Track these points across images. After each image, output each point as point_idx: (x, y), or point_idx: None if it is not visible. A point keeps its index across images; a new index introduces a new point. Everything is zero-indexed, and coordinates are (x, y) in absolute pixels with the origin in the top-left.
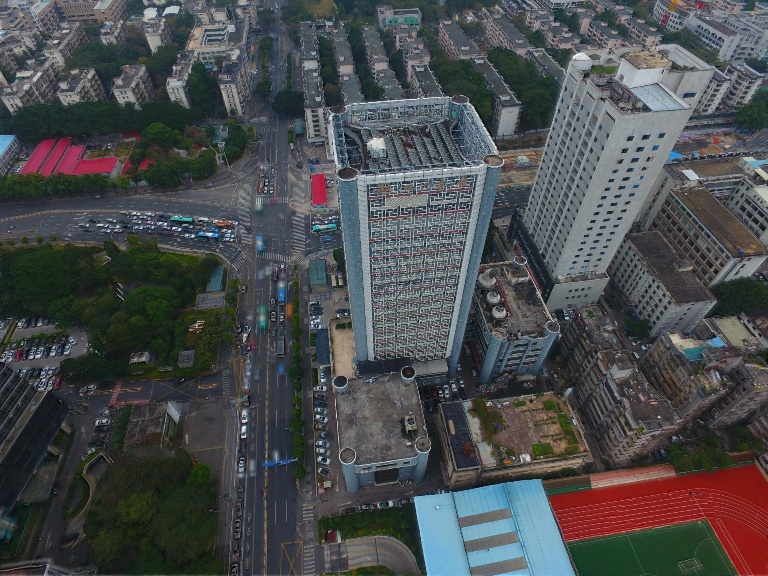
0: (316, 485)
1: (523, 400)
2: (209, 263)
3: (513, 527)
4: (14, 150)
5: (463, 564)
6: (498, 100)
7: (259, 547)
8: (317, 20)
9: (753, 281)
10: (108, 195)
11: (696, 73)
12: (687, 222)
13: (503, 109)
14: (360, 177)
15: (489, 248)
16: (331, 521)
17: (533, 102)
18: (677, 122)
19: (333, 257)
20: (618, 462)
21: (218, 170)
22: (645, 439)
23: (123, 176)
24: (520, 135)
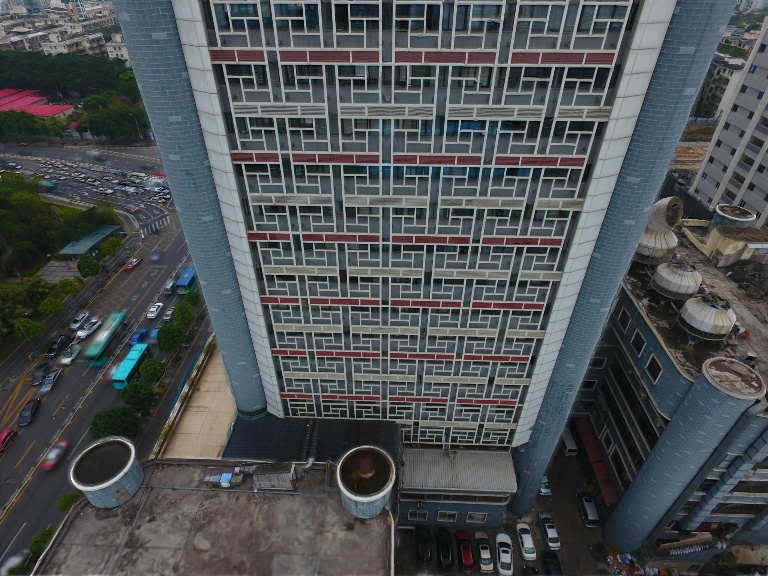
0: None
1: None
2: (93, 214)
3: None
4: None
5: None
6: None
7: None
8: None
9: None
10: (38, 144)
11: None
12: None
13: None
14: None
15: None
16: None
17: None
18: None
19: None
20: None
21: None
22: None
23: (59, 117)
24: None
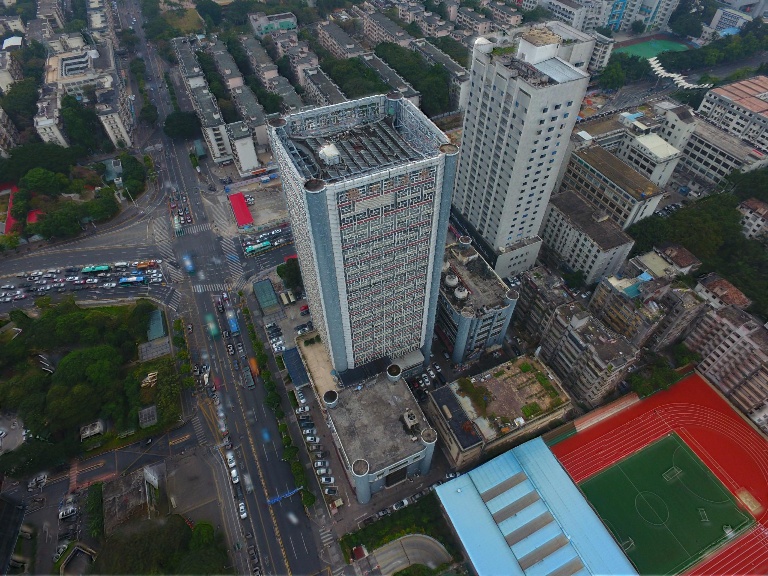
0: (327, 507)
1: (501, 369)
2: (143, 309)
3: (531, 487)
4: None
5: (497, 536)
6: None
7: None
8: (186, 35)
9: (656, 218)
10: None
11: (582, 44)
12: (592, 178)
13: None
14: (329, 186)
15: None
16: (354, 537)
17: (430, 90)
18: (581, 90)
19: (276, 275)
20: (593, 402)
21: (121, 208)
22: (614, 375)
23: (9, 235)
24: None
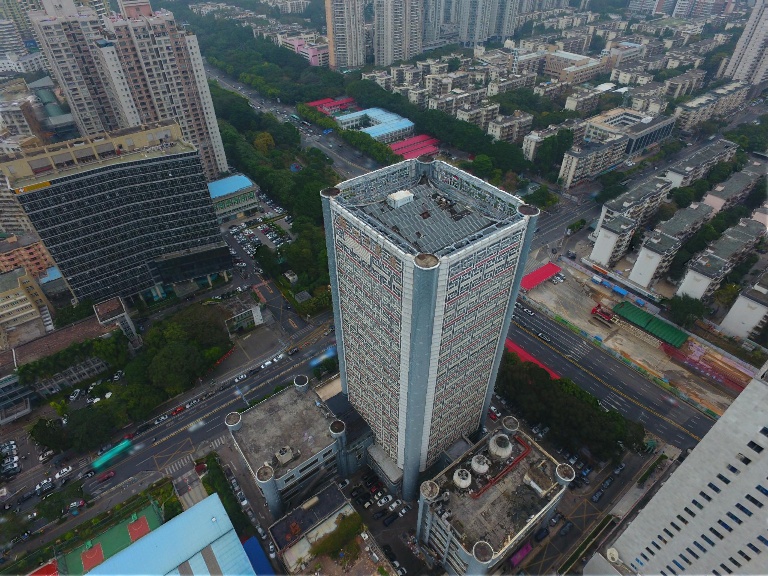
0: None
1: None
2: None
3: None
4: (406, 132)
5: (166, 568)
6: None
7: (183, 424)
8: (767, 150)
9: None
10: None
11: None
12: None
13: None
14: (330, 198)
15: (599, 451)
16: (211, 459)
17: None
18: None
19: None
20: None
21: None
22: None
23: None
24: None
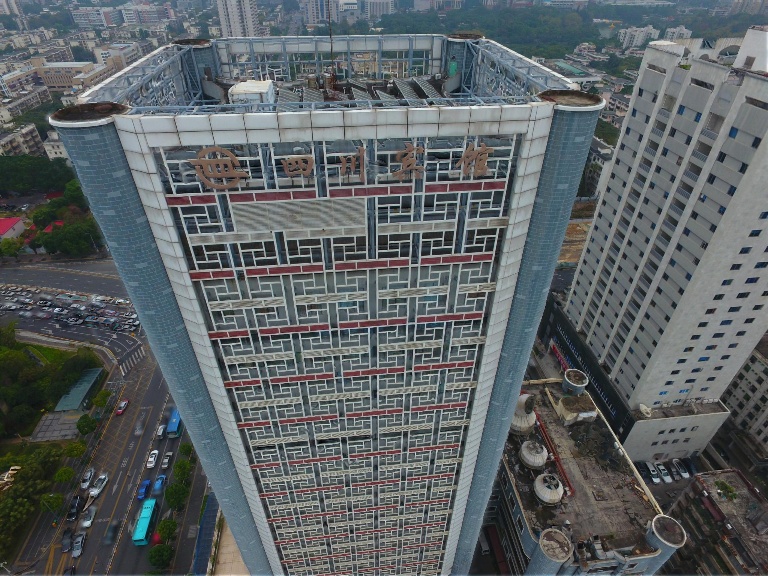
0: None
1: None
2: (77, 363)
3: None
4: None
5: None
6: None
7: None
8: None
9: None
10: None
11: None
12: None
13: None
14: (120, 117)
15: None
16: None
17: None
18: None
19: None
20: None
21: None
22: None
23: (13, 239)
24: None
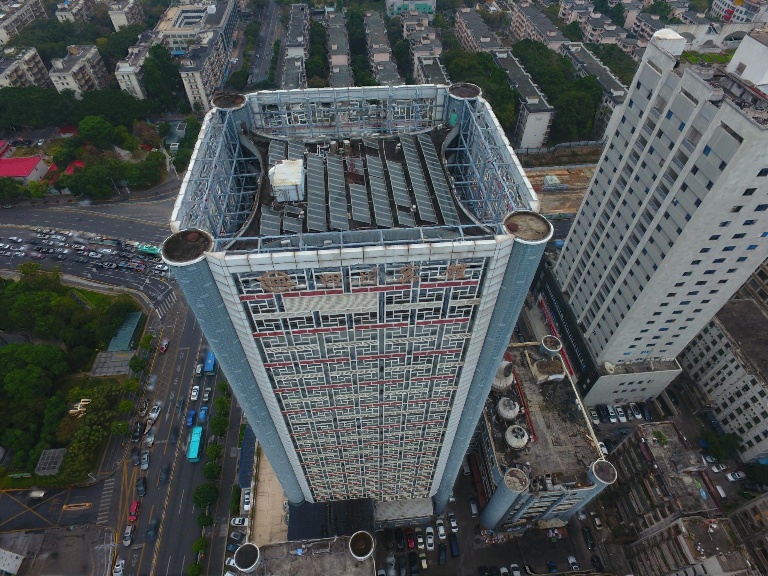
0: None
1: None
2: (120, 309)
3: None
4: None
5: None
6: (523, 103)
7: None
8: (316, 5)
9: None
10: (22, 205)
11: None
12: None
13: (529, 115)
14: (211, 257)
15: None
16: None
17: (569, 107)
18: None
19: None
20: None
21: (166, 178)
22: None
23: (39, 182)
24: (549, 148)
